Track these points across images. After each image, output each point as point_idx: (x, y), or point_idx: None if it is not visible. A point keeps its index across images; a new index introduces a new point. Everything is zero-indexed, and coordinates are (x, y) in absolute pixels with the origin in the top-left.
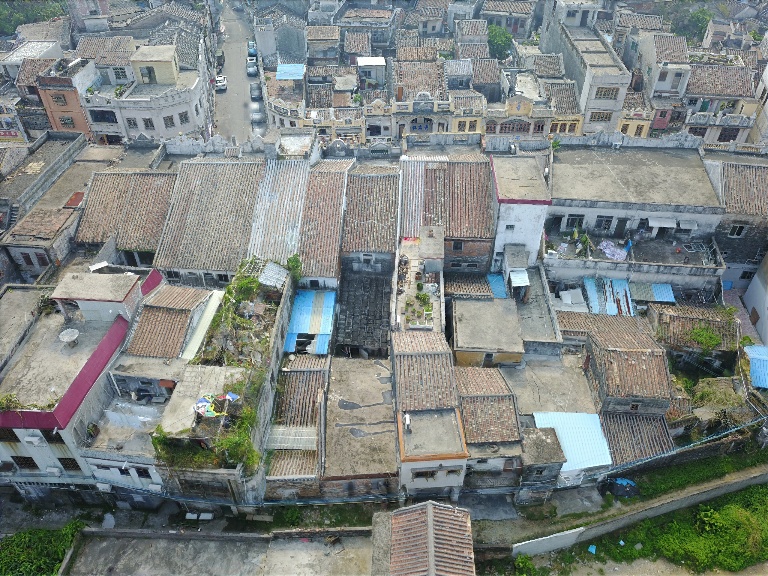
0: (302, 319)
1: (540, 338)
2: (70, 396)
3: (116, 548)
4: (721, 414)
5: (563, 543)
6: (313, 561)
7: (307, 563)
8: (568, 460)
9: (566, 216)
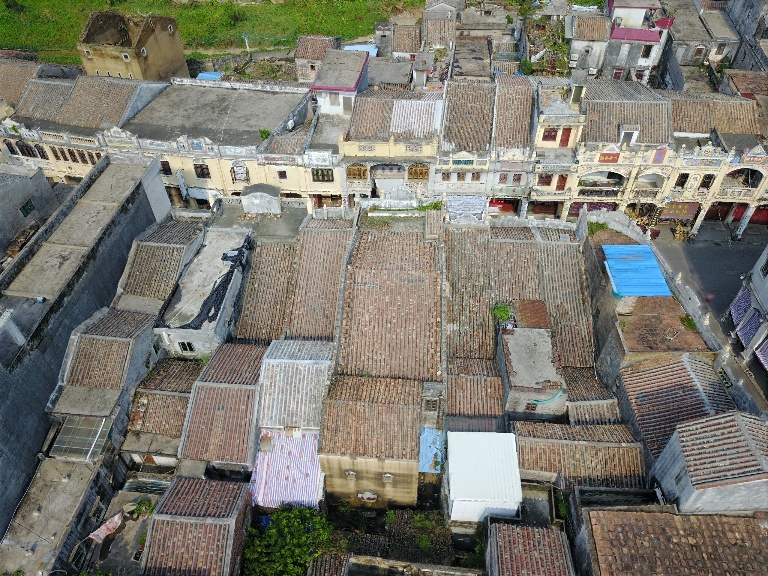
0: None
1: None
2: None
3: None
4: None
5: None
6: None
7: None
8: None
9: None
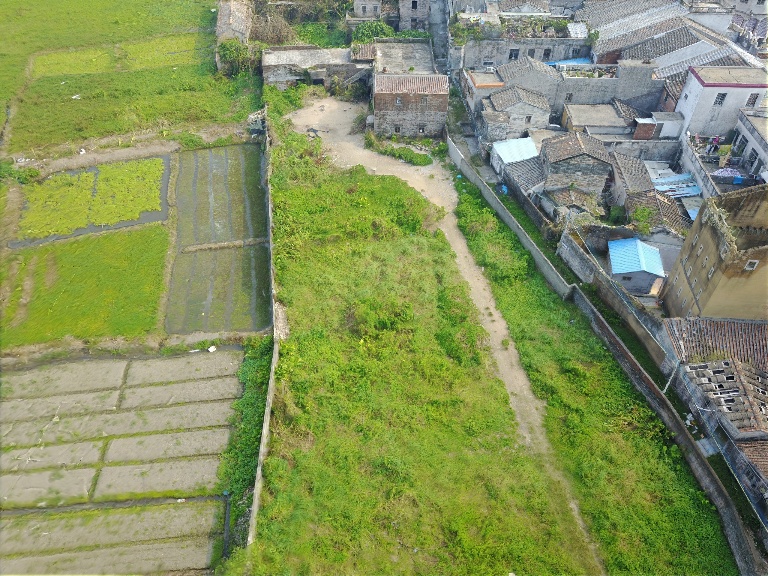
0: (566, 63)
1: None
2: None
3: (425, 49)
4: None
5: None
6: None
7: None
8: (502, 148)
9: (741, 135)
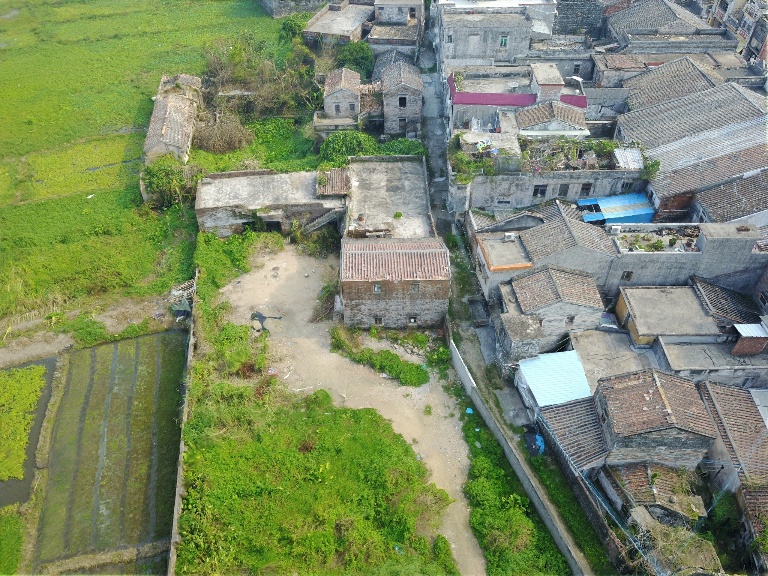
0: (614, 202)
1: (679, 361)
2: (470, 96)
3: (418, 172)
4: (650, 538)
5: (466, 384)
6: (418, 234)
7: (416, 232)
8: (533, 373)
9: None
